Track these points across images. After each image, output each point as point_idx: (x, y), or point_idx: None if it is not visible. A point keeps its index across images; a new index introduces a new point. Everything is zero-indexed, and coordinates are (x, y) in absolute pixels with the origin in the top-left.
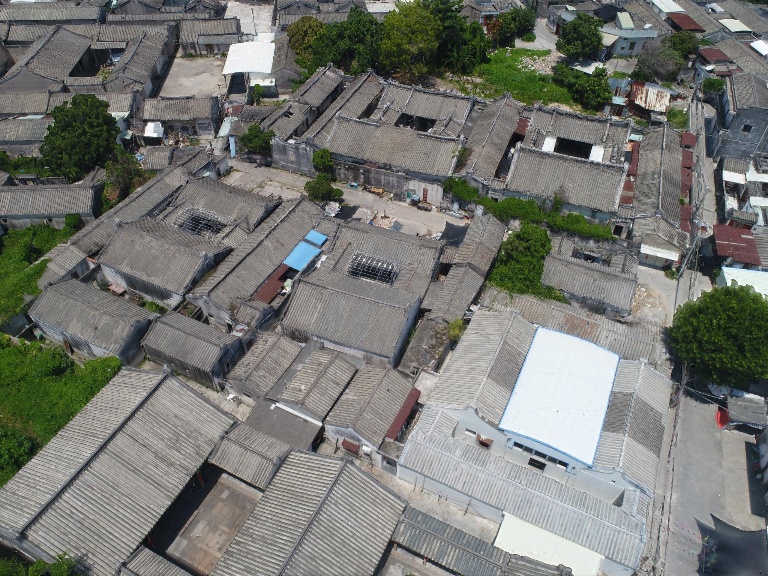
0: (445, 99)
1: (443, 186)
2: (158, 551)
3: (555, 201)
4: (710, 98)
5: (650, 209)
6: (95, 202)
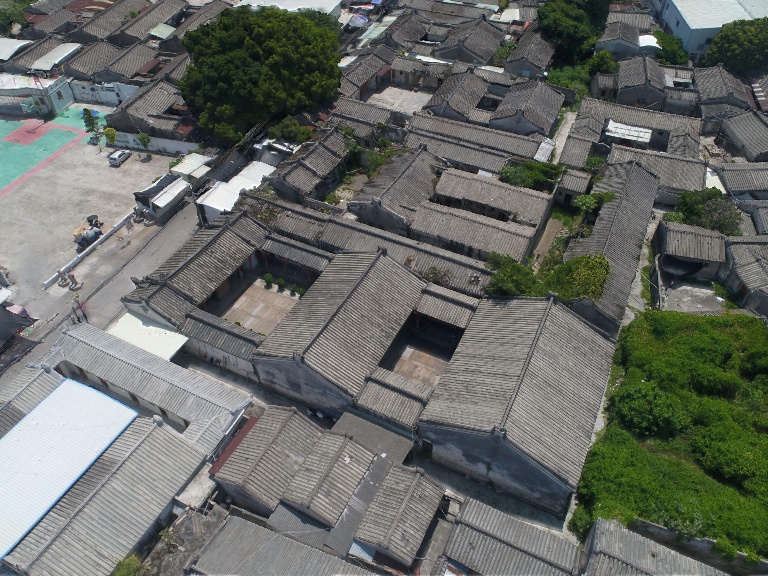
0: None
1: None
2: None
3: None
4: None
5: None
6: None
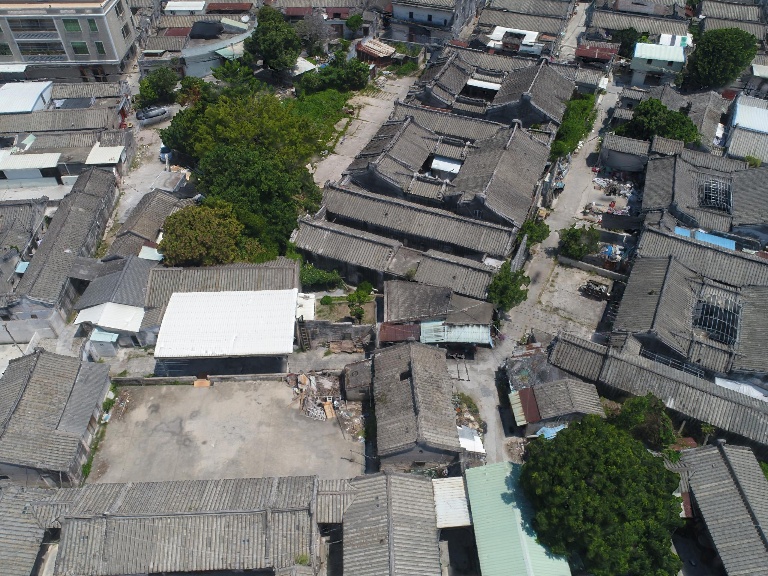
0: (404, 137)
1: None
2: None
3: (568, 106)
4: (352, 35)
5: (568, 71)
6: None
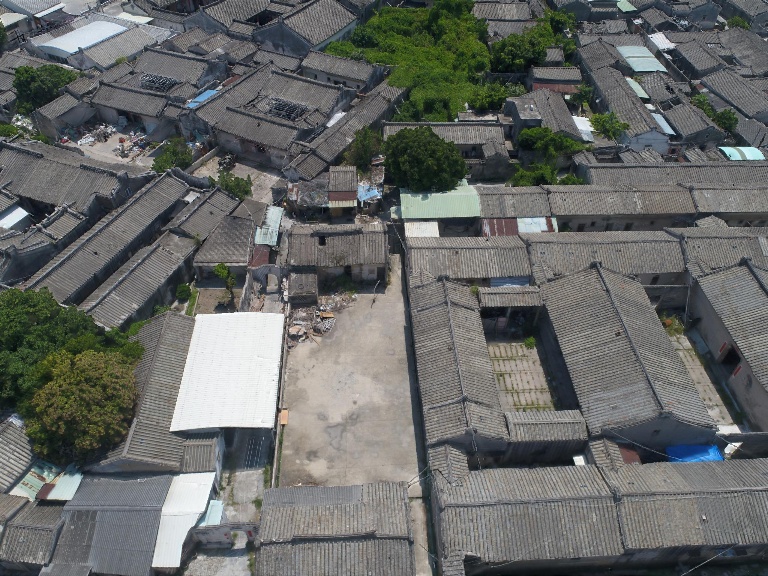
0: None
1: (54, 144)
2: None
3: None
4: None
5: None
6: None
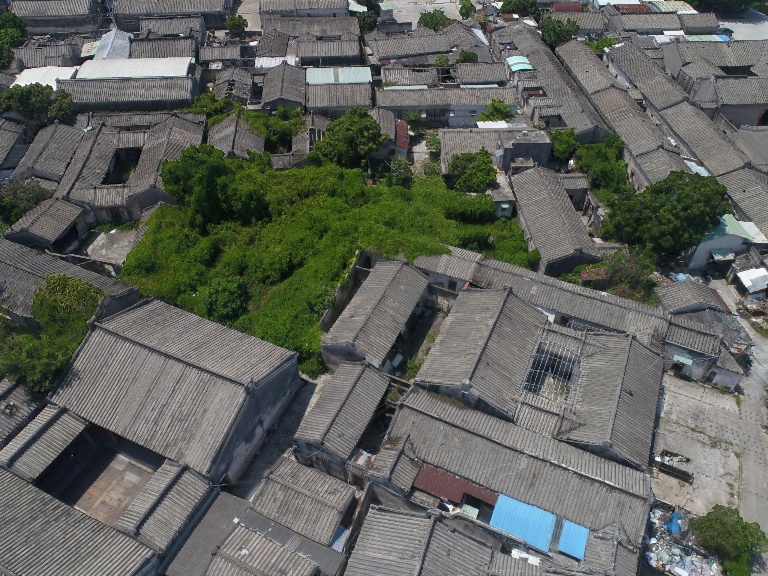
0: None
1: None
2: (116, 446)
3: None
4: None
5: None
6: (564, 262)
